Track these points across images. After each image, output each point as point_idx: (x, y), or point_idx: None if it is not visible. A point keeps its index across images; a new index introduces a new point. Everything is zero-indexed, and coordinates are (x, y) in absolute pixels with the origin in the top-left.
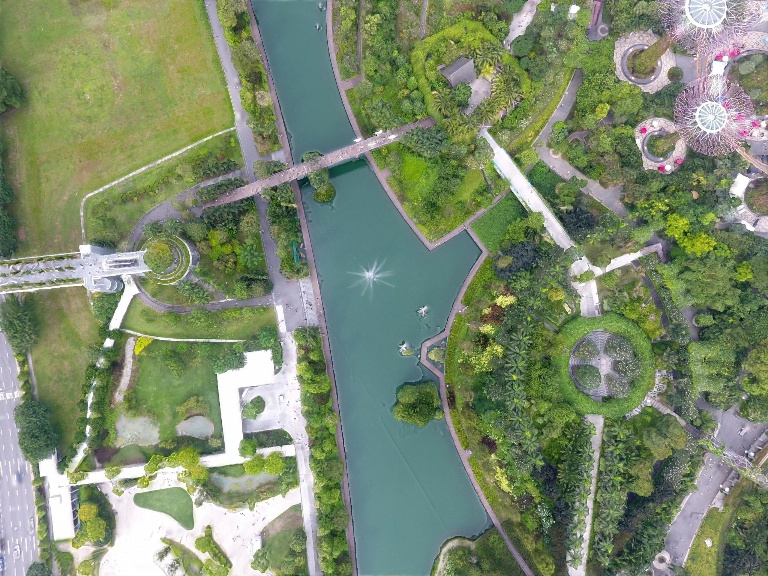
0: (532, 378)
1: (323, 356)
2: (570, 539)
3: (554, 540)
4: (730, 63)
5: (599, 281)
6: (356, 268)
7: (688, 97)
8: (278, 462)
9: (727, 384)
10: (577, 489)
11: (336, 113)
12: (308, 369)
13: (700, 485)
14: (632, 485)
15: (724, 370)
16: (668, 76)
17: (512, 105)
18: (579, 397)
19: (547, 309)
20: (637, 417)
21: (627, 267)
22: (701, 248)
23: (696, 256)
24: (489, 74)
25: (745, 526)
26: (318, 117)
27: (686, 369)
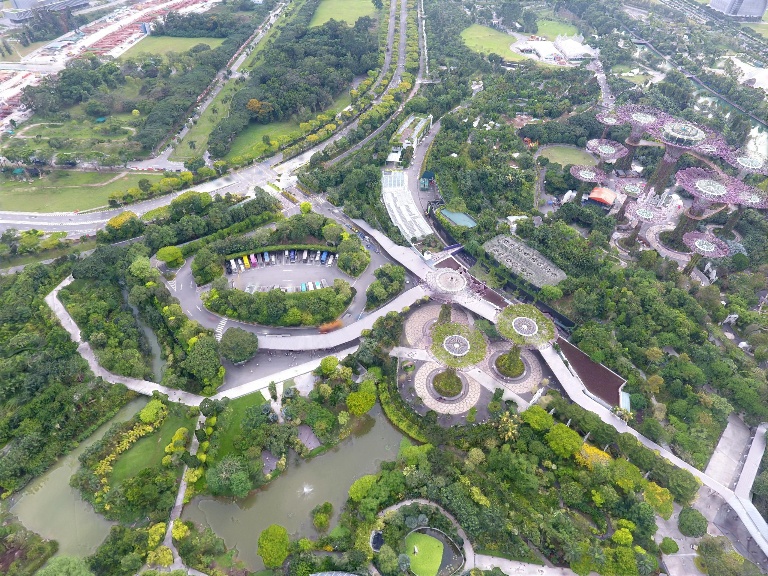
0: None
1: None
2: None
3: None
4: None
5: None
6: None
7: None
8: None
9: None
10: None
11: None
12: None
13: None
14: None
15: None
16: None
17: None
18: None
19: None
20: None
21: None
22: None
23: None
24: None
25: None
26: None
27: None
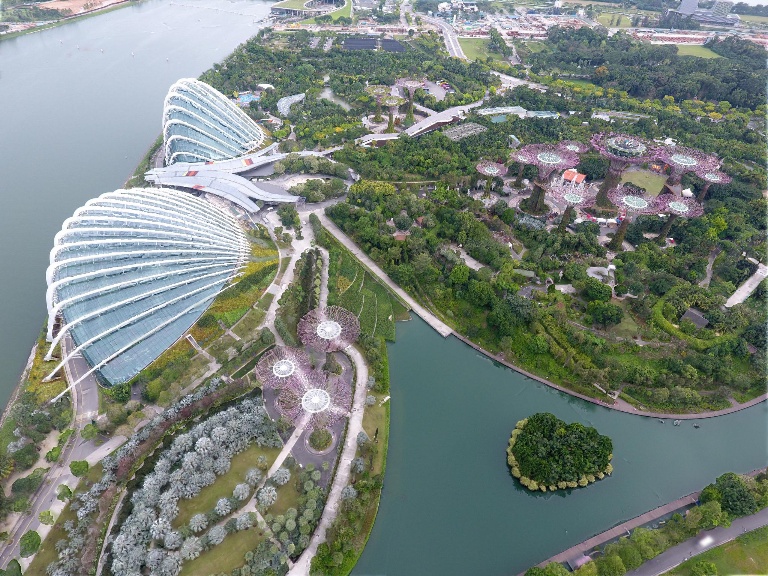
0: None
1: None
2: None
3: None
4: None
5: (767, 264)
6: None
7: None
8: None
9: None
10: None
11: (761, 413)
12: None
13: None
14: None
15: None
16: None
17: None
18: None
19: None
20: None
21: None
22: (724, 222)
23: (727, 225)
24: None
25: None
26: (765, 434)
27: None
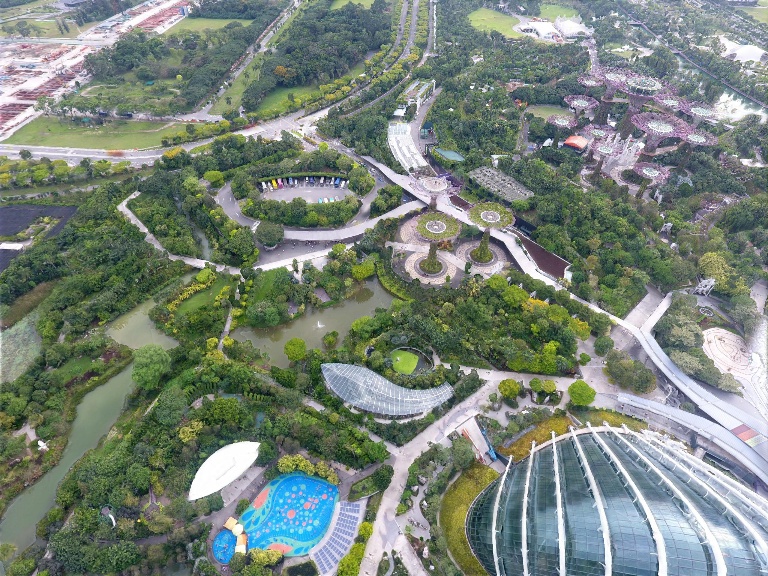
0: None
1: (760, 101)
2: None
3: None
4: None
5: None
6: (766, 117)
7: None
8: (761, 77)
9: None
10: None
11: None
12: (767, 92)
13: None
14: None
15: None
16: None
17: None
18: None
19: None
20: None
21: None
22: None
23: None
24: None
25: None
26: None
27: None
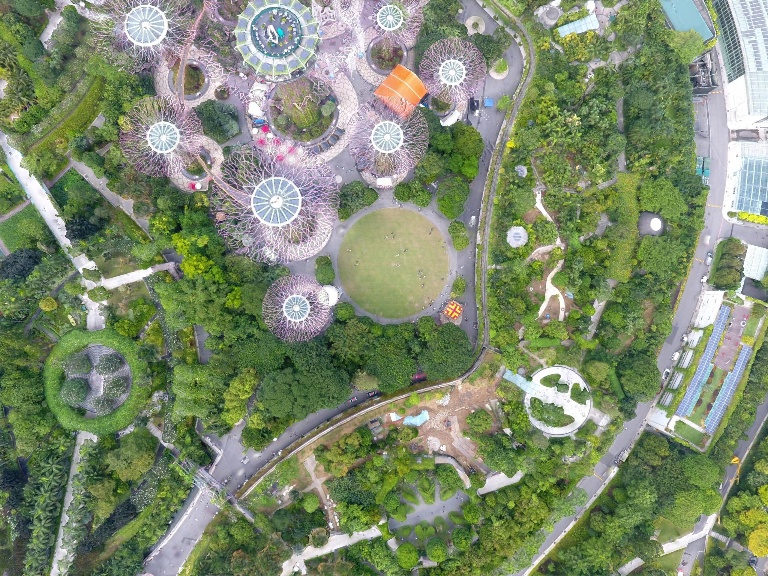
0: (5, 387)
1: None
2: (26, 554)
3: (14, 554)
4: (278, 86)
5: None
6: None
7: (142, 115)
8: None
9: (213, 410)
10: (36, 504)
11: None
12: None
13: (195, 511)
14: (91, 505)
15: (209, 396)
16: (215, 94)
17: (26, 109)
18: (61, 411)
19: (50, 319)
20: (125, 436)
21: (138, 283)
22: (191, 270)
23: (191, 278)
24: (4, 76)
25: (210, 556)
26: None
27: (170, 392)
